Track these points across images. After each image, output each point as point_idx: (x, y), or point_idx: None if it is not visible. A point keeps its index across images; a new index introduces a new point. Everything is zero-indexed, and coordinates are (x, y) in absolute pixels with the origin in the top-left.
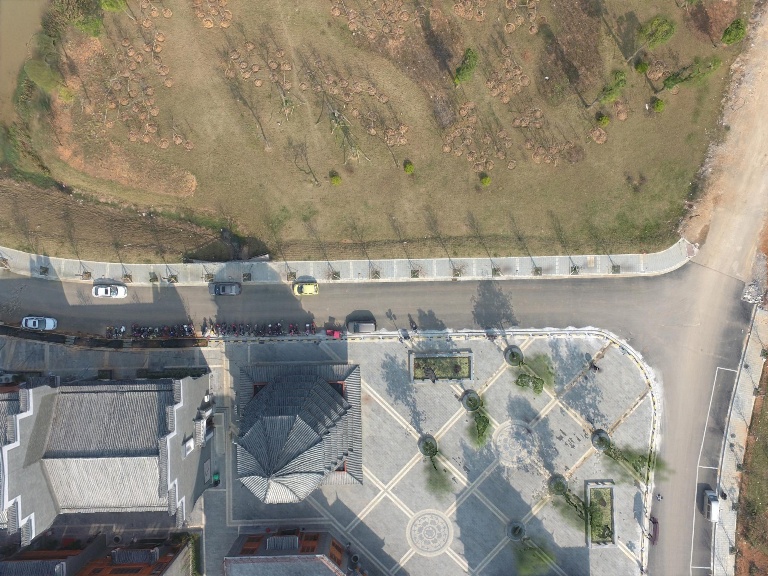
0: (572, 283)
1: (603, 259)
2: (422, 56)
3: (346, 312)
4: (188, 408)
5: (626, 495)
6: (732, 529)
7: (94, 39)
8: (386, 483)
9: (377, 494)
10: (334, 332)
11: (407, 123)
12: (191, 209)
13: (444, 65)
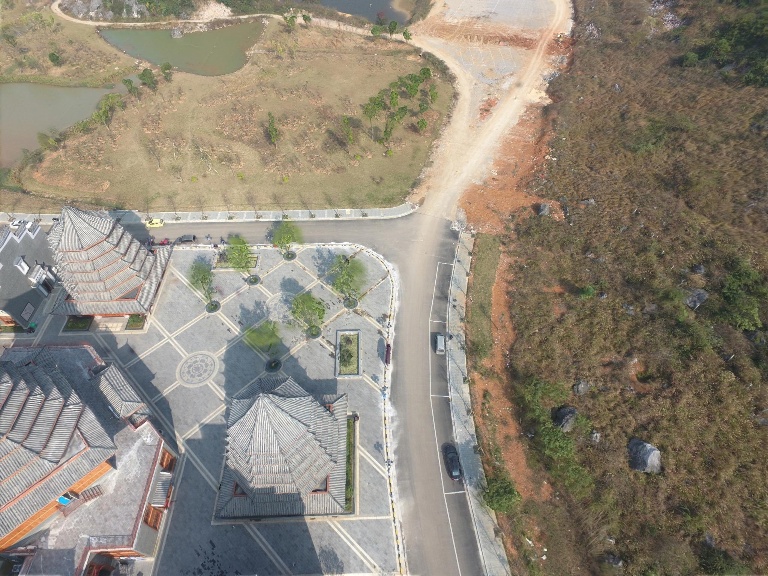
0: (335, 222)
1: (356, 211)
2: (261, 141)
3: (178, 236)
4: (36, 248)
5: (371, 340)
6: (463, 363)
7: (83, 138)
8: (172, 333)
9: (161, 340)
10: None
11: (245, 161)
12: (100, 199)
13: (272, 143)
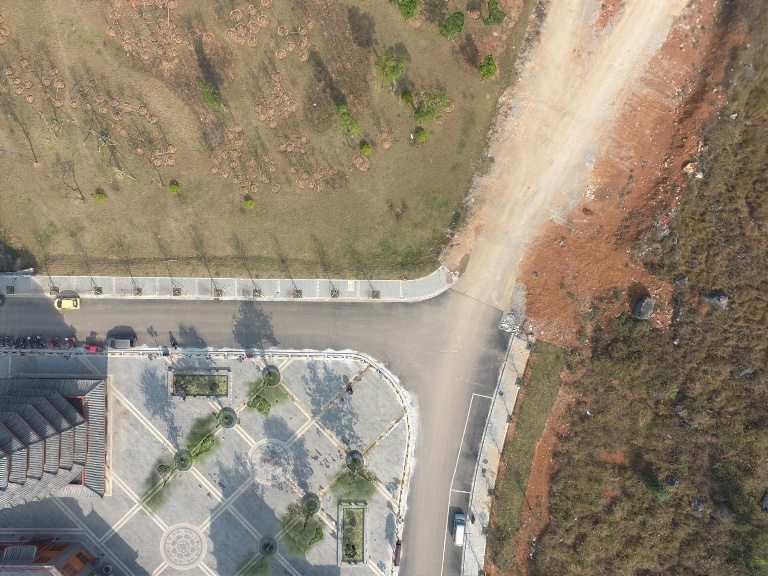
0: (332, 306)
1: (363, 284)
2: (194, 78)
3: (108, 327)
4: None
5: (378, 516)
6: (481, 553)
7: None
8: (142, 496)
9: (132, 507)
10: (91, 347)
11: (176, 144)
12: None
13: (215, 88)
